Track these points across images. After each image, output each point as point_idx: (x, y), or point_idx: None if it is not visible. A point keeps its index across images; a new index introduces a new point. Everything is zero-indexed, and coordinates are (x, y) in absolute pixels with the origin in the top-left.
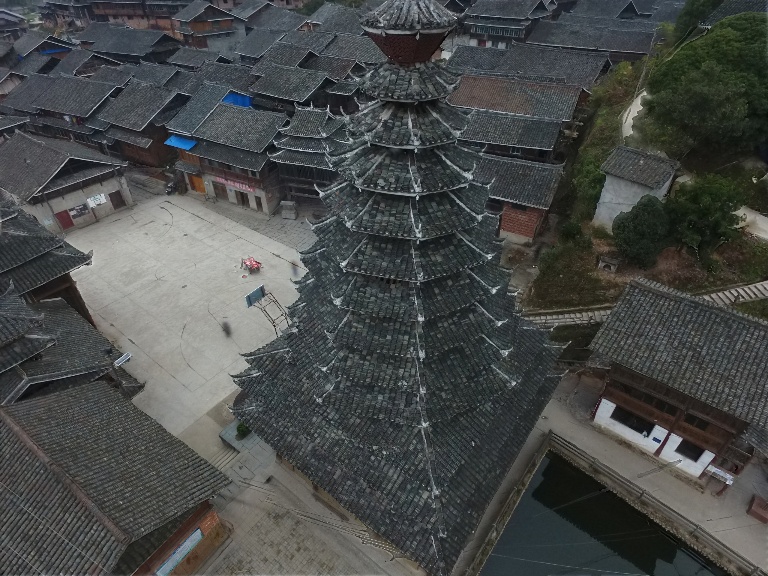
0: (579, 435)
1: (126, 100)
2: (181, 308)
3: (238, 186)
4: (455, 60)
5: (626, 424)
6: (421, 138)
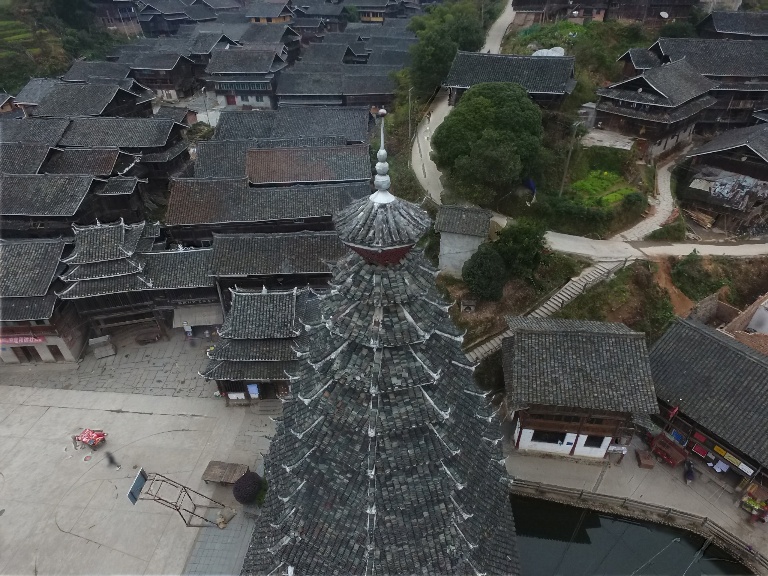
0: (514, 466)
1: None
2: (14, 547)
3: (16, 341)
4: (223, 127)
5: (544, 441)
6: None
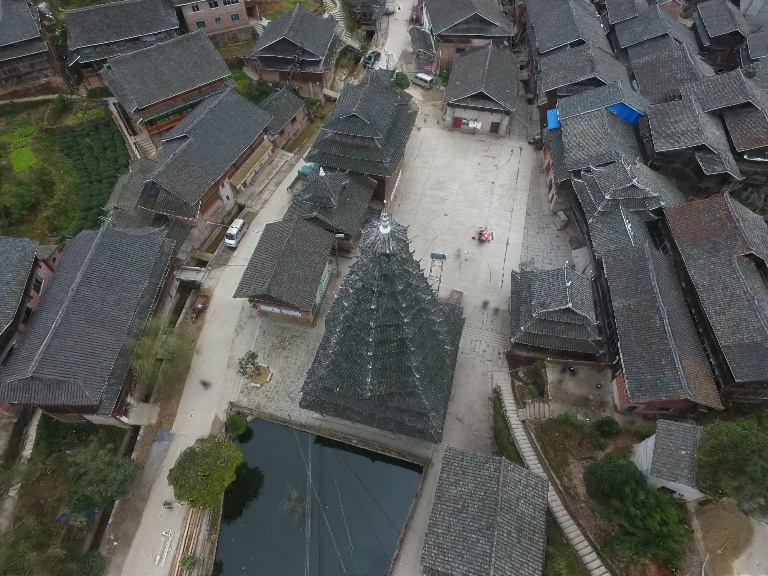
0: None
1: (567, 58)
2: (428, 225)
3: None
4: None
5: None
6: (361, 277)
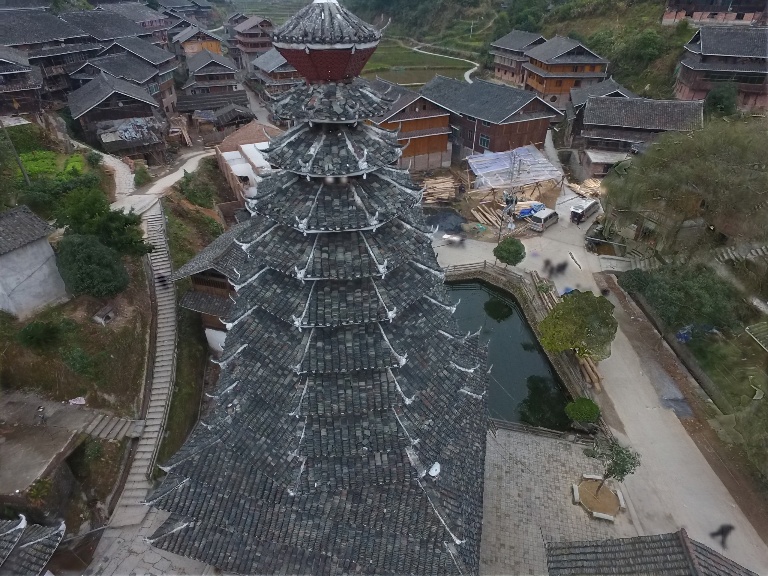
0: None
1: None
2: None
3: None
4: None
5: None
6: None
